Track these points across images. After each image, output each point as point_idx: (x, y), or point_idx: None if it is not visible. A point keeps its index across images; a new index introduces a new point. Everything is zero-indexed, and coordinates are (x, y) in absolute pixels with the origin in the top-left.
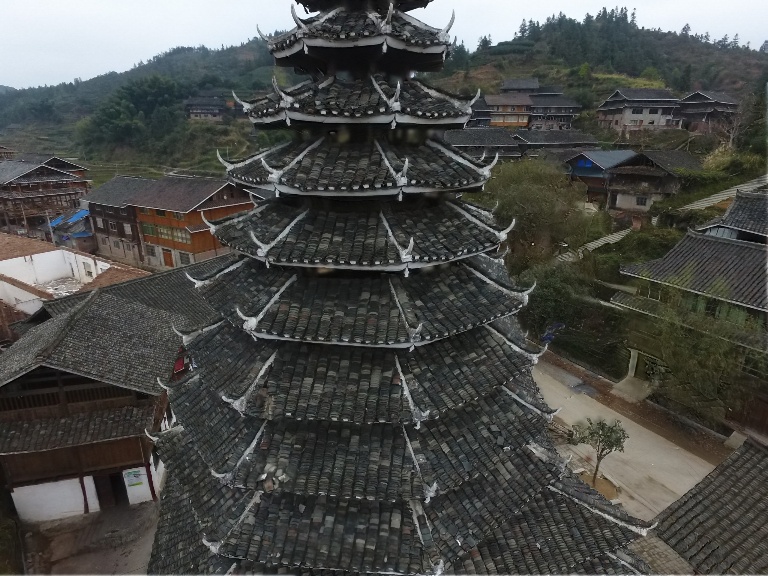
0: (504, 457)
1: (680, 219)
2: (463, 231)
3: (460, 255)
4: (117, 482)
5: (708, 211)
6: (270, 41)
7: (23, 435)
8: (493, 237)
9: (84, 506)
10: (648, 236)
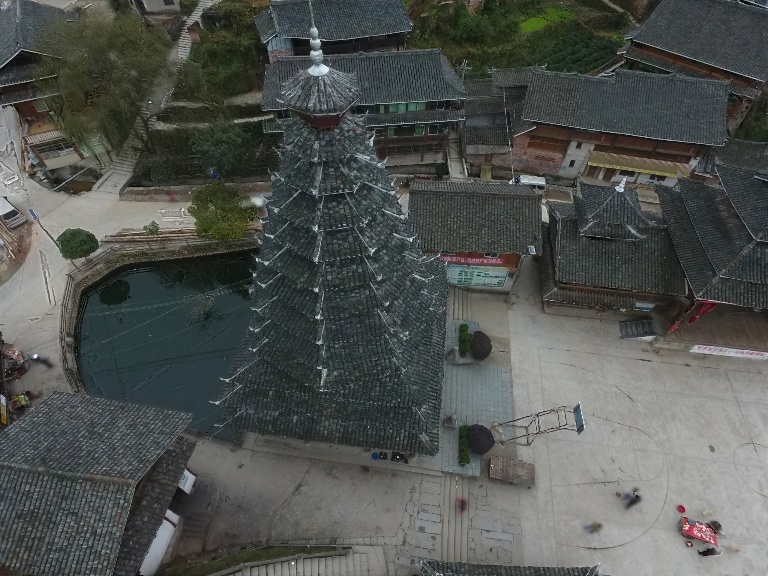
0: (425, 270)
1: (220, 18)
2: None
3: None
4: (177, 494)
5: (233, 4)
6: (316, 191)
7: (139, 535)
8: (399, 205)
9: (172, 526)
10: (212, 46)
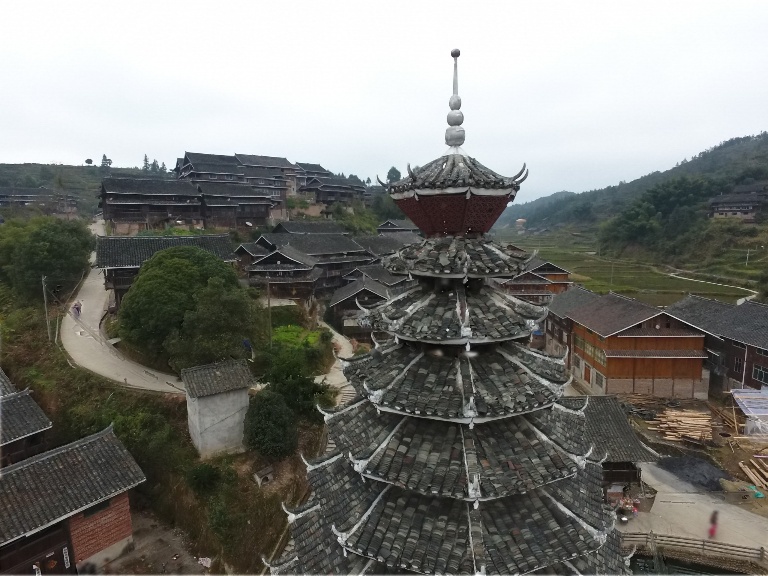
0: None
1: None
2: (446, 542)
3: (408, 568)
4: None
5: None
6: None
7: None
8: (464, 571)
9: None
10: None
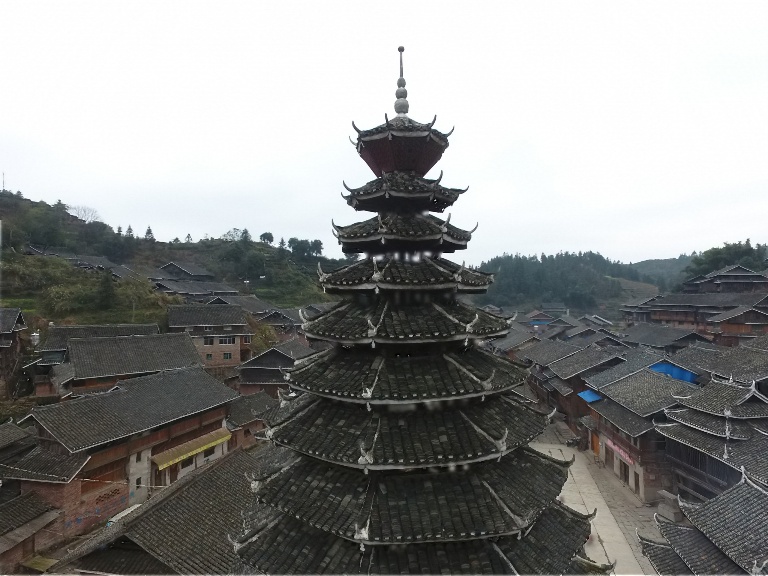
0: None
1: None
2: None
3: None
4: None
5: None
6: None
7: None
8: None
9: None
10: None
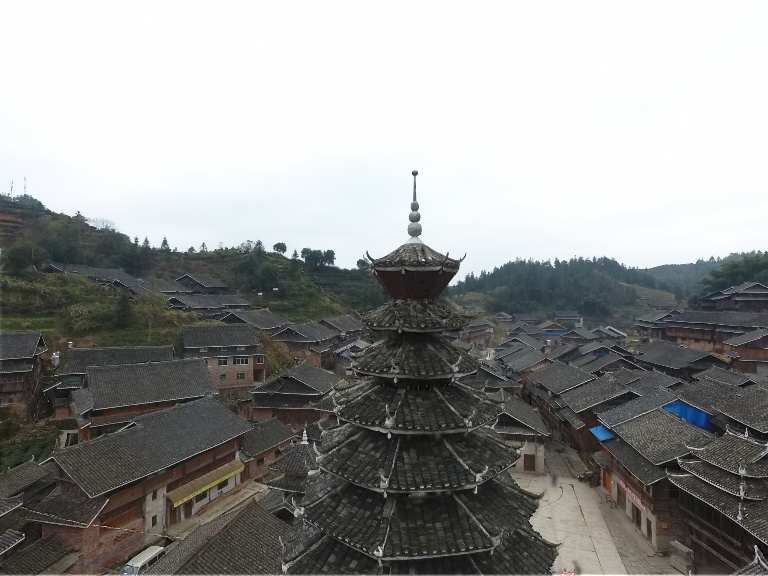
0: None
1: None
2: None
3: None
4: None
5: None
6: (480, 360)
7: None
8: None
9: None
10: None
